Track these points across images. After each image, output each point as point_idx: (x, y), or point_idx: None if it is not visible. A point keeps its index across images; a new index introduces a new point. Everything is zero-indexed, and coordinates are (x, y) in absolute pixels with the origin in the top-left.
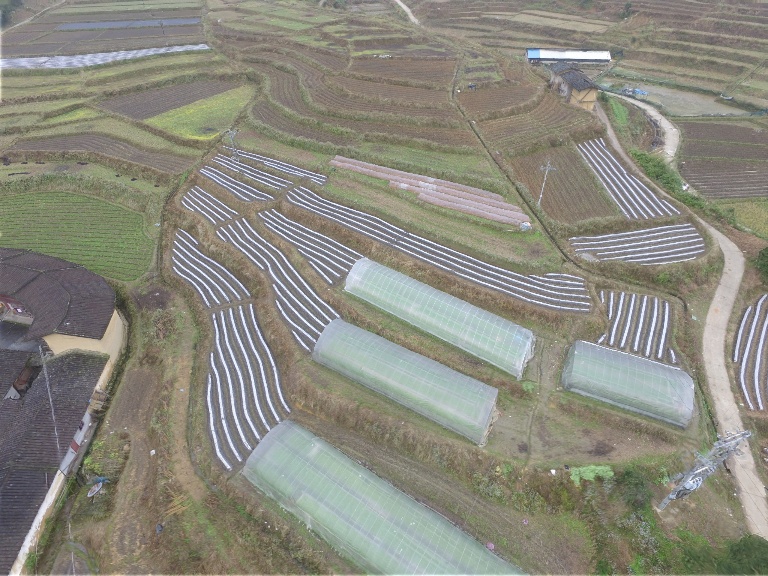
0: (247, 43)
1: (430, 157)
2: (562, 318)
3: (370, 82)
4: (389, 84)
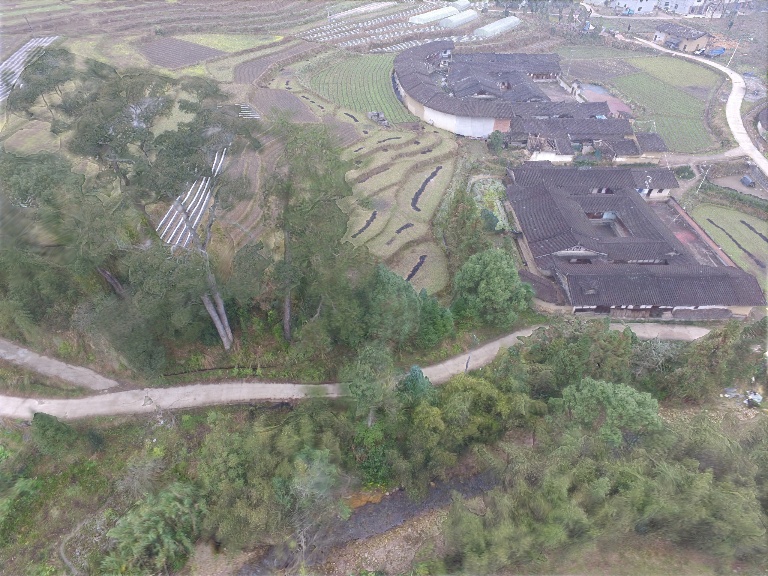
0: (66, 26)
1: (339, 6)
2: (438, 7)
3: (235, 4)
4: (243, 2)
